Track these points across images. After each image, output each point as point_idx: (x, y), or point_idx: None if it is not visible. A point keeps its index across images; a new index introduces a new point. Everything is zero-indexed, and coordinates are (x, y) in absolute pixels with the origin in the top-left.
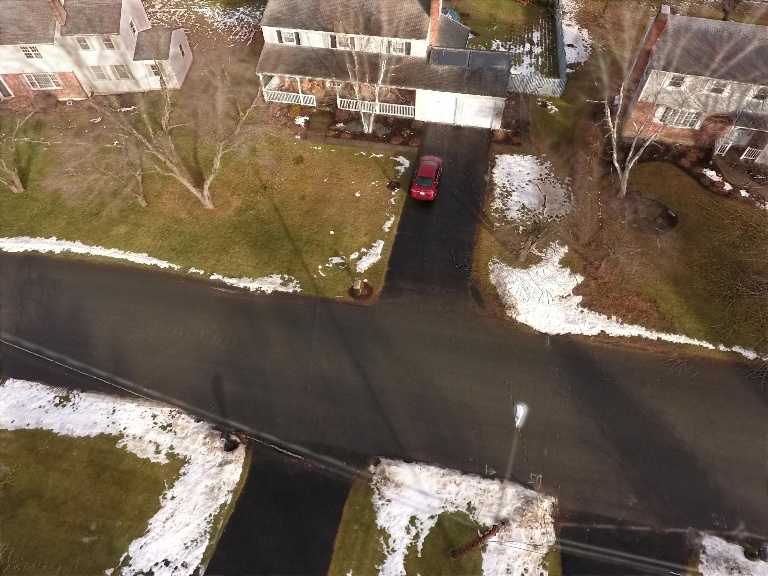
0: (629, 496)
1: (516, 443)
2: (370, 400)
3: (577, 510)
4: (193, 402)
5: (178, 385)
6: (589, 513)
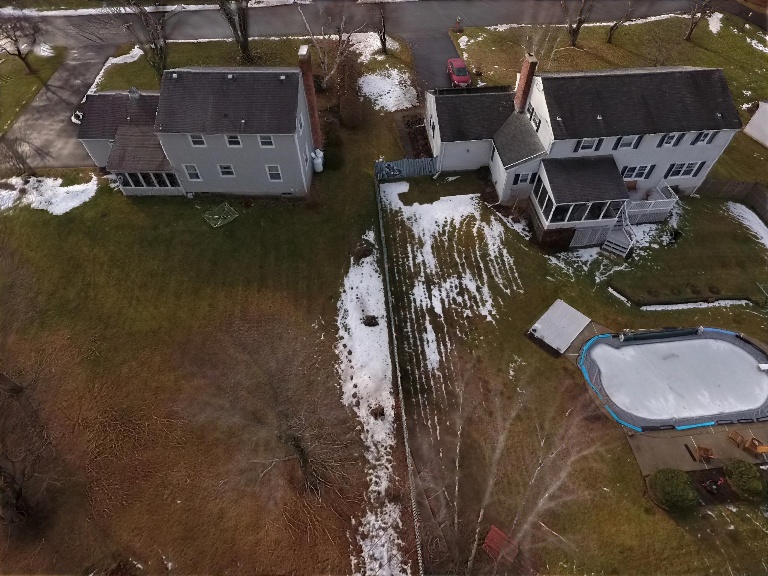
0: (332, 6)
1: (372, 8)
2: (430, 8)
3: (350, 2)
4: (493, 0)
5: (504, 2)
6: (346, 2)
